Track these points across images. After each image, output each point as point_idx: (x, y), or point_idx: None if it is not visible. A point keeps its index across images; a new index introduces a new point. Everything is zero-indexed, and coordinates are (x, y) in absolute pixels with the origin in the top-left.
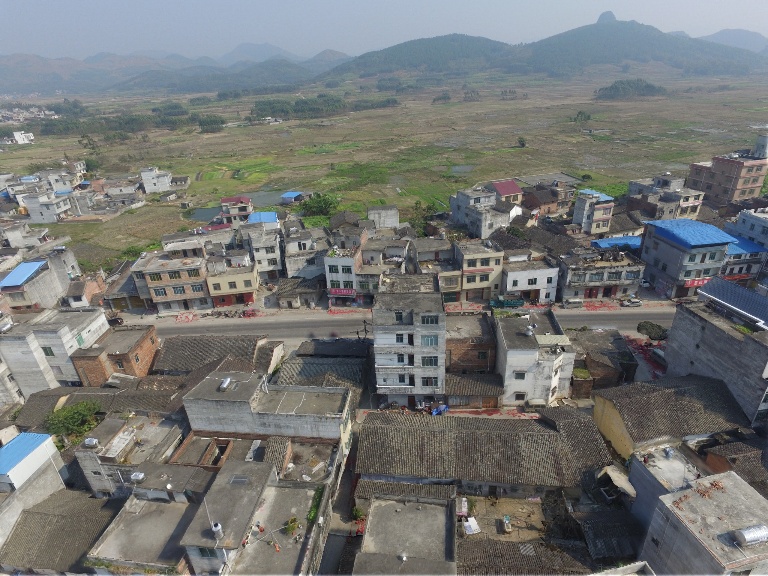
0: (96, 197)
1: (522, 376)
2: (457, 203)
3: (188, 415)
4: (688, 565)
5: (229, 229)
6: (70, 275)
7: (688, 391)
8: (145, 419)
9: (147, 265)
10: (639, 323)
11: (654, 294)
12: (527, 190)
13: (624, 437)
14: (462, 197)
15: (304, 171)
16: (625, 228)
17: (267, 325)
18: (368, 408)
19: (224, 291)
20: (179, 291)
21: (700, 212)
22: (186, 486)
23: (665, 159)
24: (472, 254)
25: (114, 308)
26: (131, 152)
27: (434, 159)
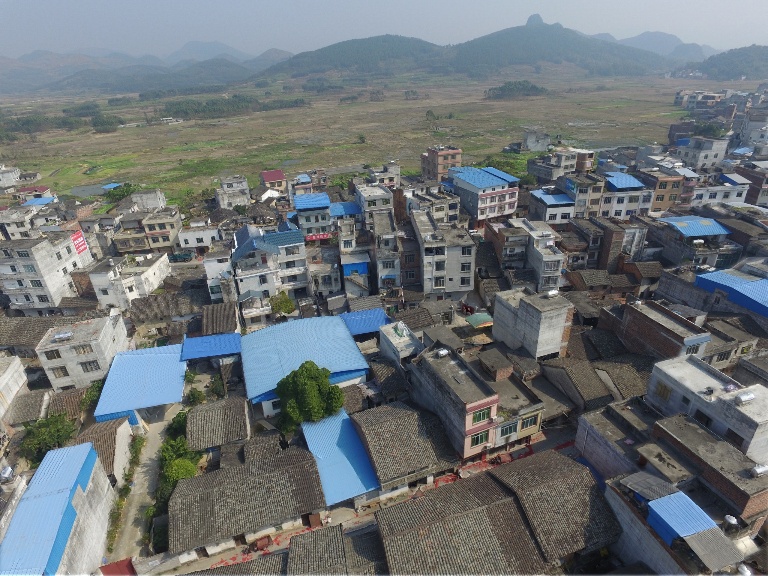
0: None
1: (106, 292)
2: None
3: None
4: None
5: (3, 211)
6: None
7: (187, 293)
8: None
9: None
10: None
11: None
12: None
13: None
14: None
15: (153, 166)
16: None
17: None
18: None
19: None
20: None
21: None
22: None
23: None
24: None
25: None
26: (4, 152)
27: (277, 154)
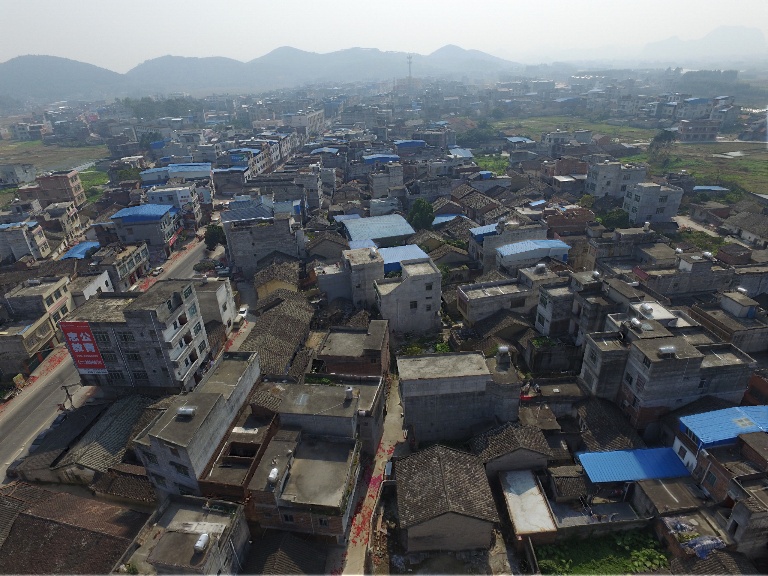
0: None
1: (225, 307)
2: None
3: (192, 464)
4: (373, 277)
5: None
6: None
7: (277, 260)
8: (141, 550)
9: None
10: (194, 267)
11: (154, 263)
12: None
13: None
14: None
15: None
16: (55, 245)
17: None
18: None
19: None
20: None
21: None
22: (292, 440)
23: None
24: (47, 291)
25: None
26: None
27: None
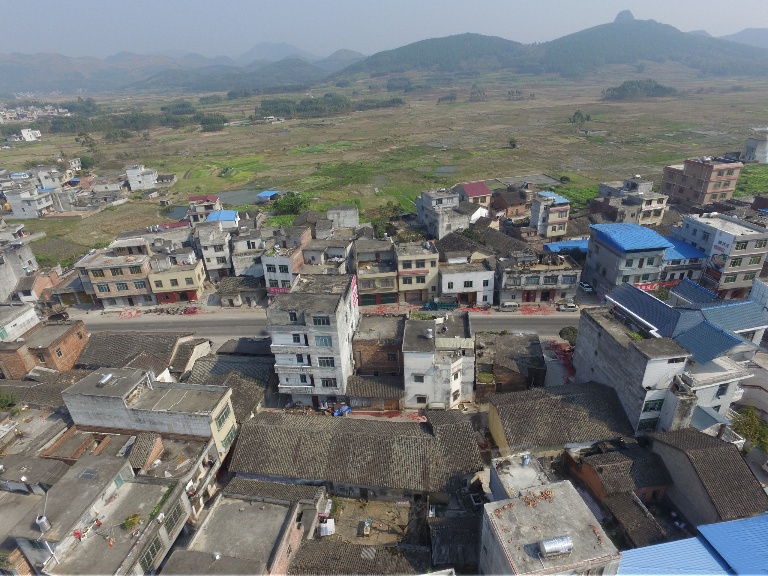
0: (81, 194)
1: (421, 379)
2: (422, 204)
3: (69, 409)
4: (501, 574)
5: (186, 227)
6: (26, 270)
7: (576, 398)
8: (36, 412)
9: (91, 261)
10: (562, 328)
11: (594, 299)
12: (499, 192)
13: (505, 443)
14: (425, 198)
15: (290, 170)
16: (584, 231)
17: (204, 323)
18: (274, 407)
19: (166, 288)
20: (122, 287)
21: (666, 216)
22: (40, 479)
23: (653, 161)
24: (406, 255)
25: (63, 303)
26: (127, 150)
27: (422, 159)
